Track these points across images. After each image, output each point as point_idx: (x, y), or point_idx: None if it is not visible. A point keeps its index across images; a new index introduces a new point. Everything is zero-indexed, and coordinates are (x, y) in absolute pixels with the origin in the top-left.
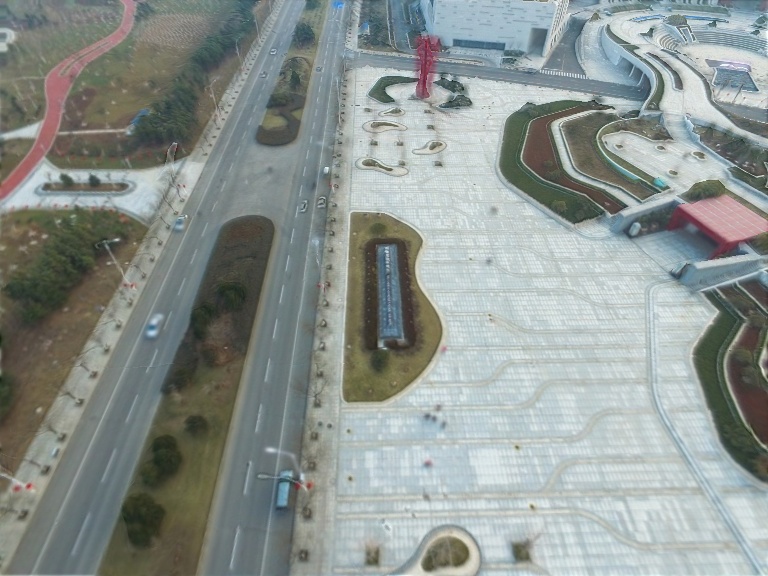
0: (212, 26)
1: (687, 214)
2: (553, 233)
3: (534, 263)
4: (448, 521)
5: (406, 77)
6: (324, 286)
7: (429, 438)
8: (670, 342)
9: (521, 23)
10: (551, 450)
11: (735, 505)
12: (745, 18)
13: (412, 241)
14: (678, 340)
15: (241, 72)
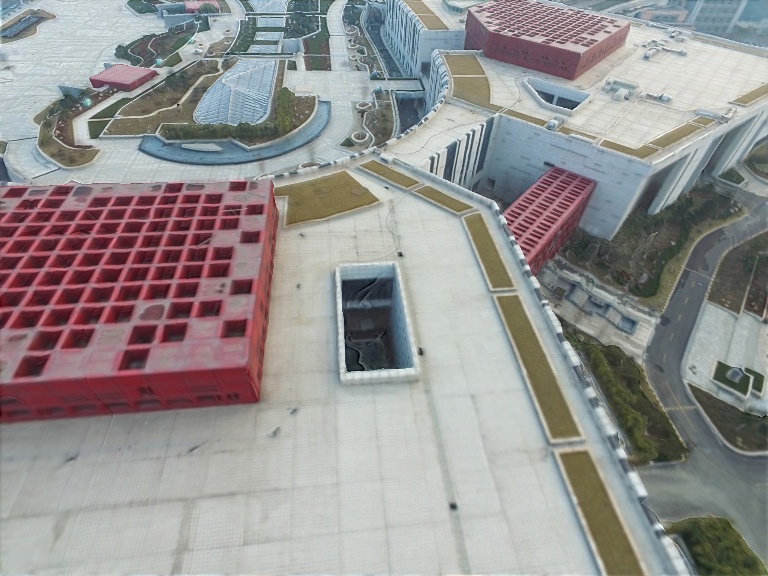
0: None
1: None
2: (127, 17)
3: None
4: None
5: None
6: None
7: None
8: (134, 38)
9: None
10: (46, 55)
11: None
12: None
13: None
14: None
15: None
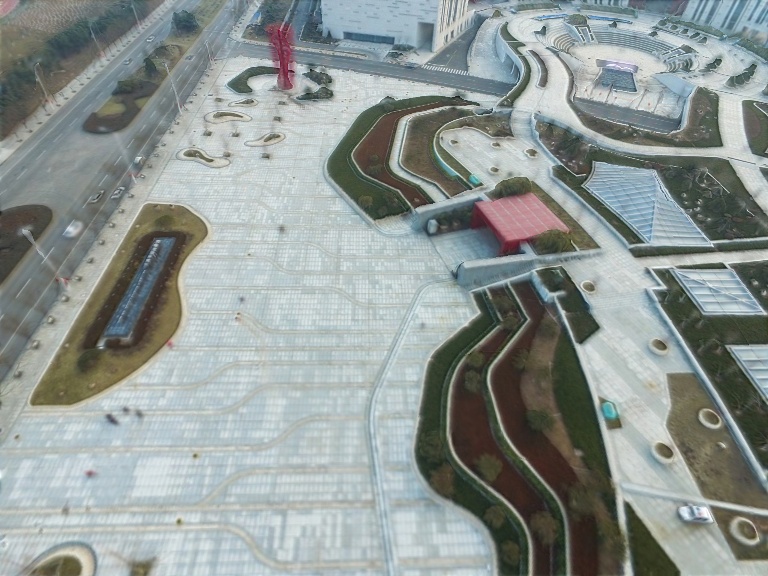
0: (94, 11)
1: (480, 212)
2: (351, 229)
3: (314, 260)
4: (76, 537)
5: (276, 68)
6: (70, 280)
7: (102, 445)
8: (415, 344)
9: (407, 17)
10: (231, 459)
11: (400, 520)
12: (651, 20)
13: (195, 235)
14: (425, 342)
15: (100, 58)
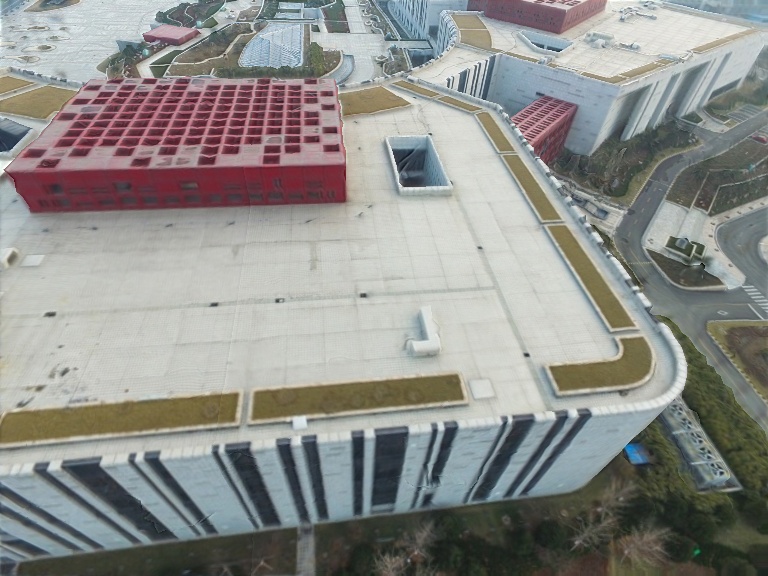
0: None
1: None
2: None
3: None
4: None
5: None
6: None
7: None
8: (169, 7)
9: None
10: None
11: None
12: None
13: None
14: None
15: None
